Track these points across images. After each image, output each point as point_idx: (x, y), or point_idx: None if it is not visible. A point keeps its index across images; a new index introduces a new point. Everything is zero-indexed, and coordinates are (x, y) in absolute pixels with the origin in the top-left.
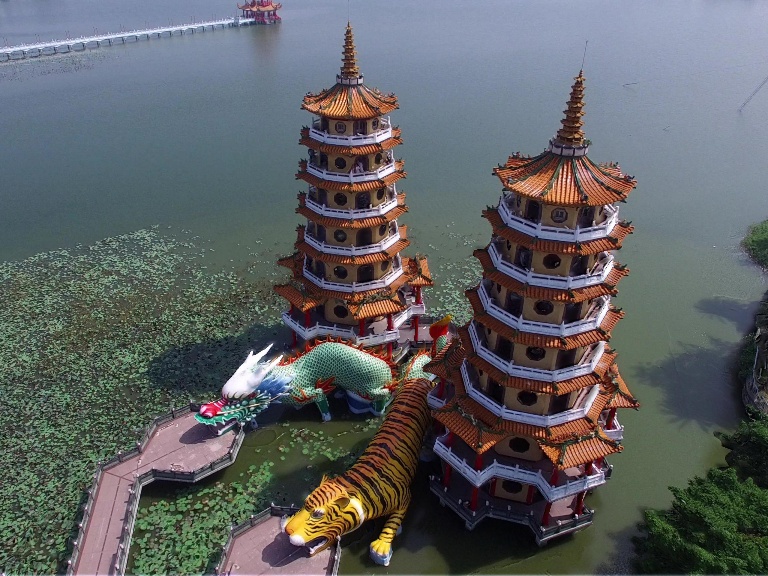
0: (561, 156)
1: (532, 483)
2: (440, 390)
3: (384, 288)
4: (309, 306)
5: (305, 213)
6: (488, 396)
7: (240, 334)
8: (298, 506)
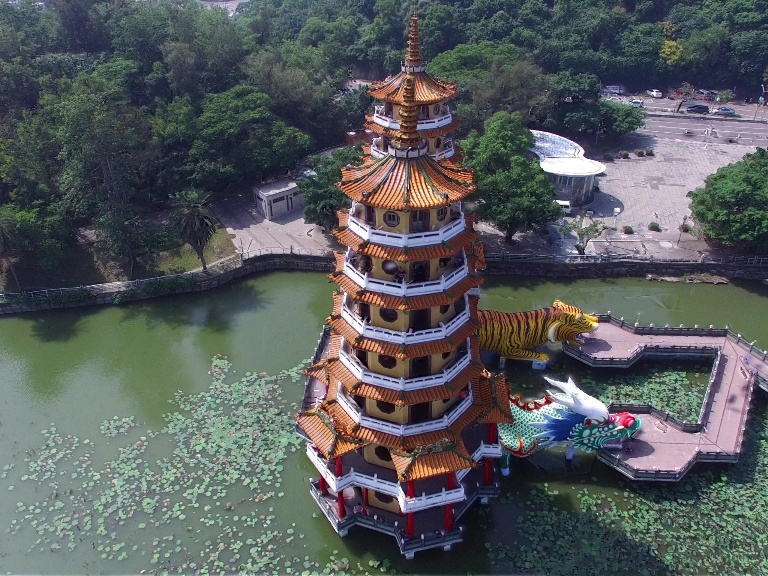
0: None
1: None
2: None
3: None
4: None
5: None
6: None
7: None
8: None
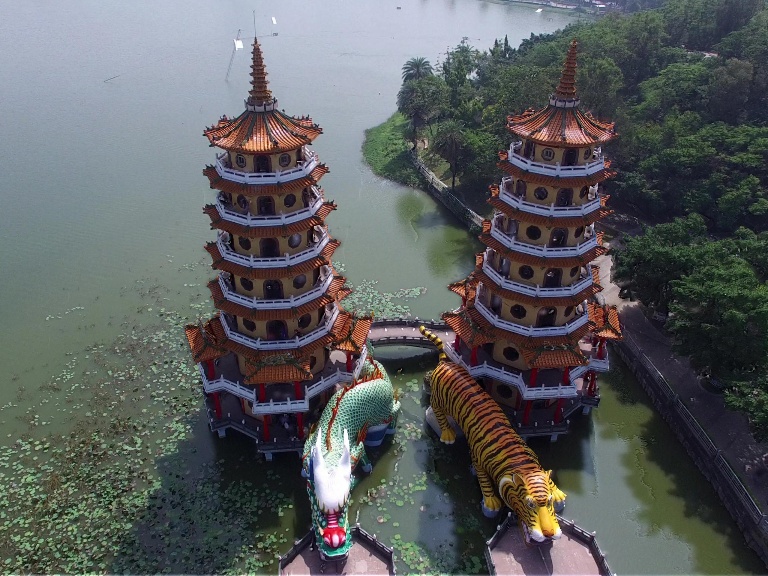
0: (573, 108)
1: (589, 369)
2: (473, 359)
3: (340, 314)
4: (309, 371)
5: (261, 275)
6: (548, 326)
7: (159, 482)
8: (466, 538)
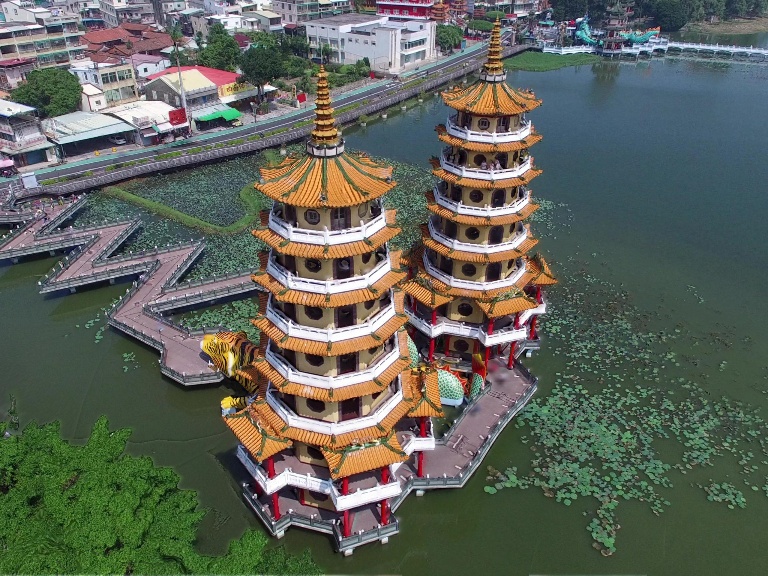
0: None
1: None
2: None
3: (447, 285)
4: (402, 261)
5: None
6: None
7: None
8: None
